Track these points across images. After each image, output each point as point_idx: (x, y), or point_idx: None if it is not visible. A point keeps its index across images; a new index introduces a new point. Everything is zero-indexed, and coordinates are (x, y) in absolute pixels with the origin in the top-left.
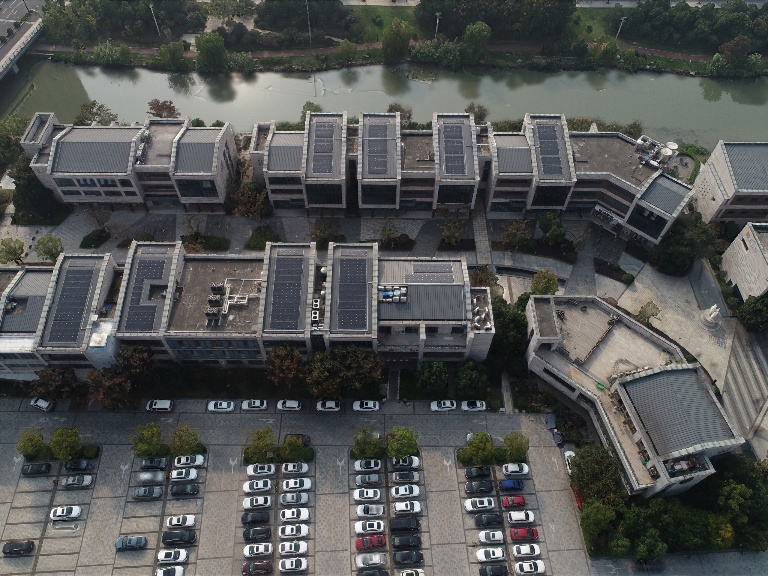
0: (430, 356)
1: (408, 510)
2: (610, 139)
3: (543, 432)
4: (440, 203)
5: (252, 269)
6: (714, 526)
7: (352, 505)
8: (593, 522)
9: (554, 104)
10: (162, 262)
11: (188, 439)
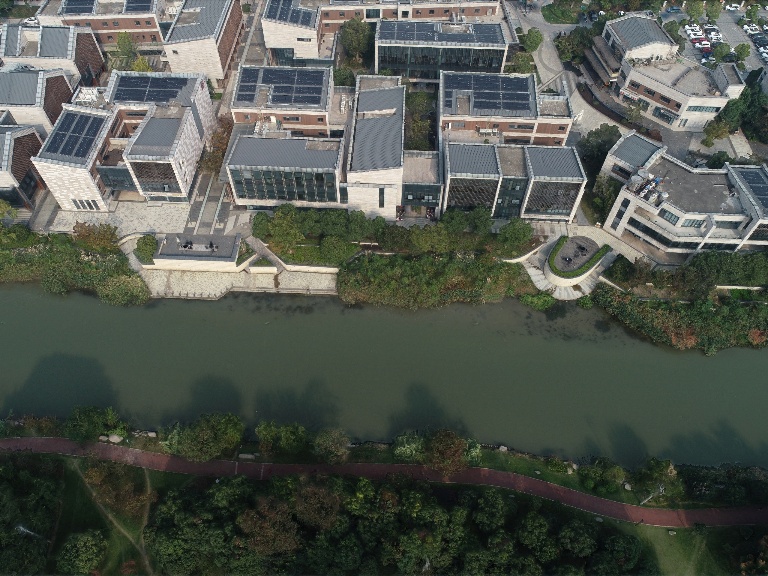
0: None
1: (767, 46)
2: (693, 210)
3: None
4: None
5: None
6: None
7: None
8: None
9: (720, 385)
10: None
11: None
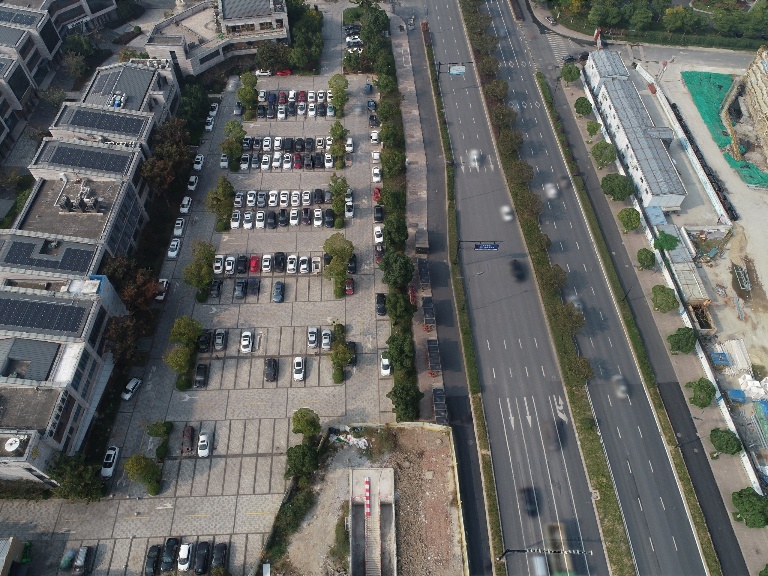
0: (172, 113)
1: (280, 140)
2: None
3: (240, 83)
4: (20, 101)
5: (50, 189)
6: (310, 14)
7: (271, 171)
8: (301, 56)
9: None
10: (15, 244)
11: (204, 242)
